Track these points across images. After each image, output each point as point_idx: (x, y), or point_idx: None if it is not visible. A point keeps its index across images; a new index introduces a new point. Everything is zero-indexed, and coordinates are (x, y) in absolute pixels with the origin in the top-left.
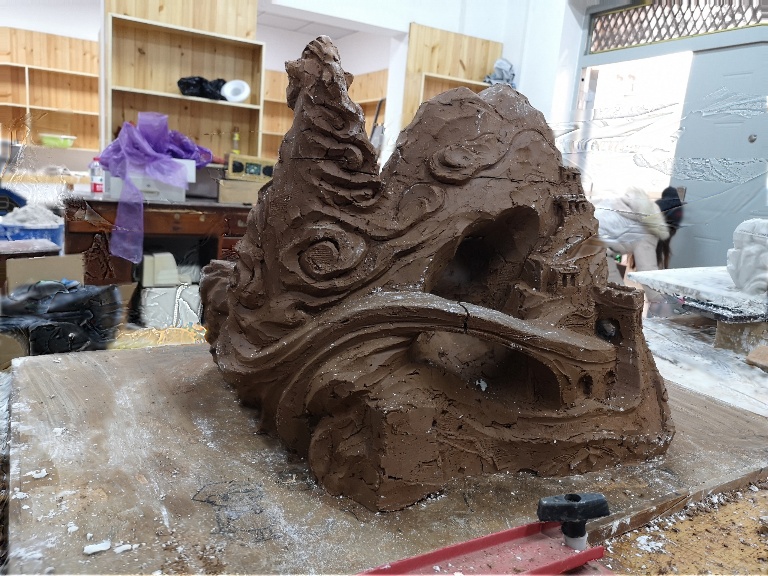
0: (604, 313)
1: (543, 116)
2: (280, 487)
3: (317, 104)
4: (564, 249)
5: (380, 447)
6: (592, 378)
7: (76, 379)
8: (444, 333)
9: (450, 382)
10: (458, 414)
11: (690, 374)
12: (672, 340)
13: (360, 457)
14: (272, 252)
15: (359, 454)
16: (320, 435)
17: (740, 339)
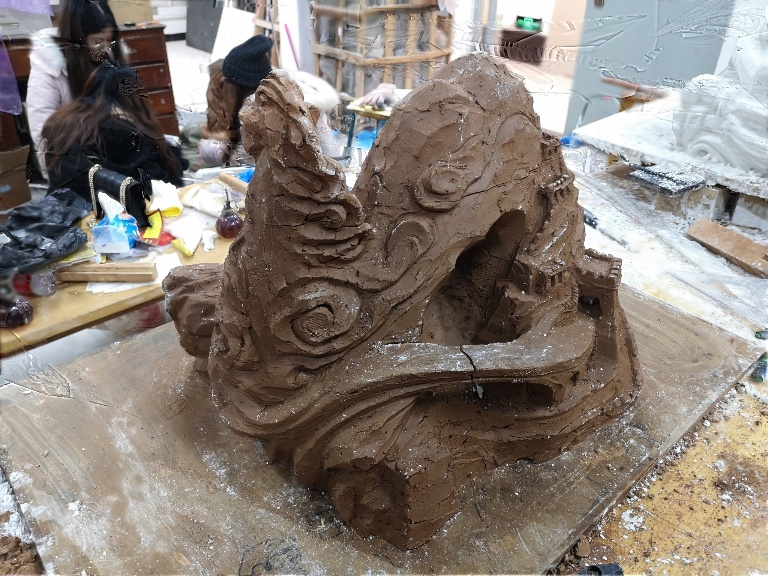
0: (585, 292)
1: None
2: (313, 538)
3: (288, 167)
4: (550, 244)
5: (405, 504)
6: (579, 371)
7: (59, 418)
8: (437, 342)
9: (453, 406)
10: (462, 432)
11: (638, 259)
12: (616, 206)
13: (386, 510)
14: (260, 320)
15: (385, 508)
16: (343, 490)
17: (680, 203)
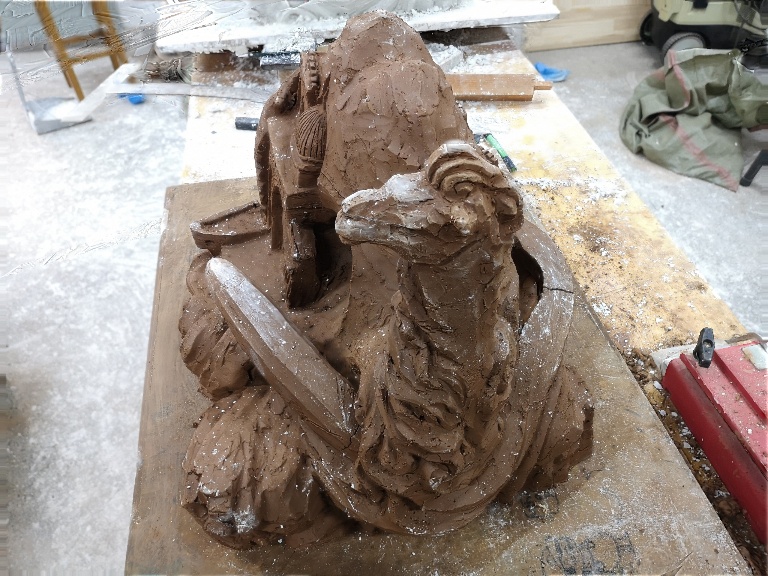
0: None
1: None
2: (553, 520)
3: None
4: None
5: None
6: None
7: None
8: None
9: None
10: None
11: None
12: (256, 100)
13: None
14: None
15: None
16: None
17: None
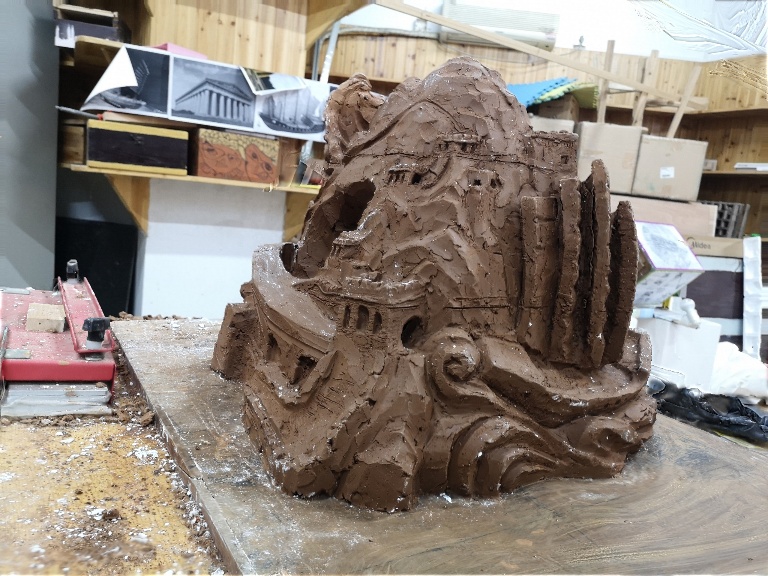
0: None
1: (465, 80)
2: None
3: None
4: (363, 223)
5: None
6: (278, 344)
7: None
8: None
9: None
10: None
11: None
12: None
13: None
14: None
15: None
16: None
17: None
